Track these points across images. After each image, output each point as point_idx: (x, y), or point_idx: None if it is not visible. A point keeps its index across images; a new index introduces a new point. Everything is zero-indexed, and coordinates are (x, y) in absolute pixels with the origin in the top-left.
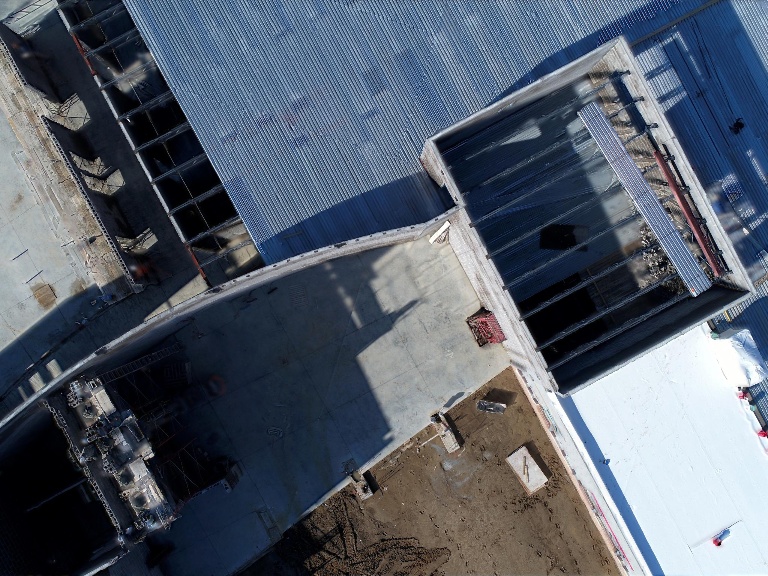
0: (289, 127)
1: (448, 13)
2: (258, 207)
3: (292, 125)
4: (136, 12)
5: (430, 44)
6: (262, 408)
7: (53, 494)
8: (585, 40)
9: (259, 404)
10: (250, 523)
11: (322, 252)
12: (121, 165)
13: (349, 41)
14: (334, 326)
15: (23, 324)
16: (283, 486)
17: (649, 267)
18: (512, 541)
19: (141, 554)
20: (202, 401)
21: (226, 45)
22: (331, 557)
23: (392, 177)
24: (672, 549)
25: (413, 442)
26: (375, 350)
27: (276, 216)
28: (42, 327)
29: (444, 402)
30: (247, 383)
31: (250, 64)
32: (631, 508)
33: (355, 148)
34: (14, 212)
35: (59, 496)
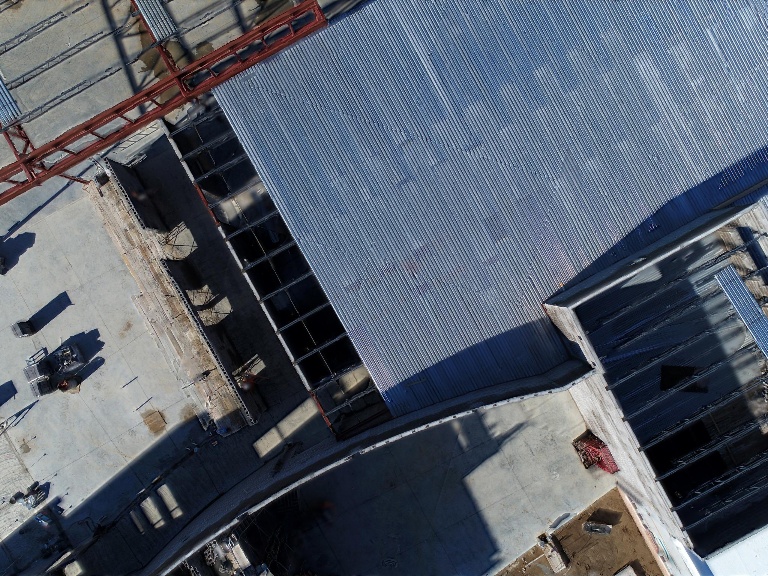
0: (412, 275)
1: (570, 158)
2: (382, 355)
3: (415, 273)
4: (260, 163)
5: (552, 190)
6: (370, 530)
7: None
8: (707, 182)
9: (367, 526)
10: None
11: None
12: (228, 292)
13: (471, 188)
14: (441, 449)
15: (134, 450)
16: None
17: None
18: None
19: None
20: (311, 524)
21: (349, 195)
22: None
23: (515, 323)
24: None
25: (519, 562)
26: (481, 472)
27: (400, 364)
28: (152, 453)
29: (550, 523)
30: (355, 506)
31: (373, 213)
32: None
33: (478, 295)
34: (123, 340)
35: None
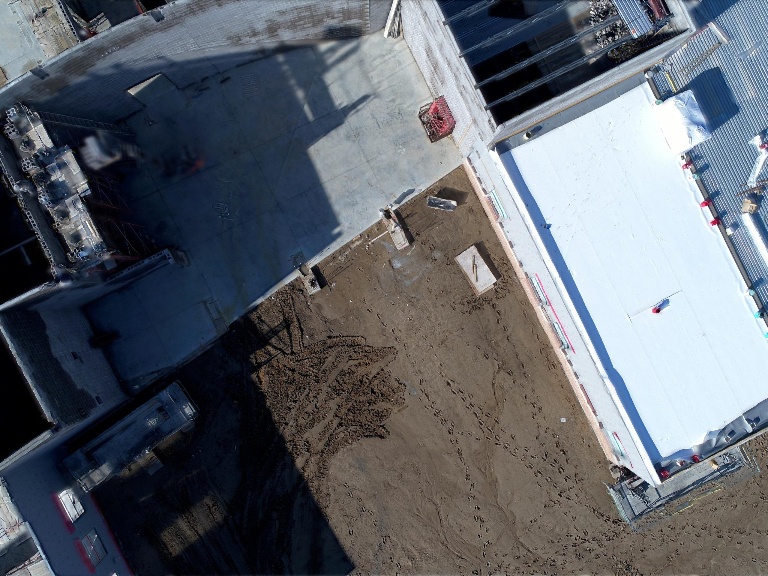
0: None
1: None
2: None
3: None
4: None
5: None
6: (211, 198)
7: None
8: None
9: (208, 194)
10: (196, 314)
11: None
12: None
13: None
14: (286, 118)
15: None
16: (230, 277)
17: (596, 36)
18: (459, 342)
19: (83, 332)
20: (151, 189)
21: None
22: (277, 352)
23: None
24: (611, 316)
25: (362, 239)
26: (327, 143)
27: None
28: None
29: (394, 198)
30: (197, 172)
31: None
32: (571, 274)
33: None
34: None
35: None
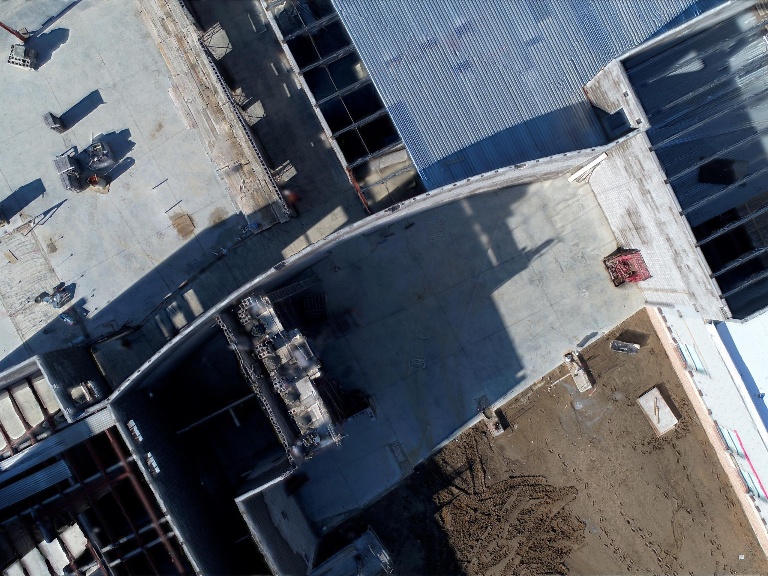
0: (454, 53)
1: None
2: (421, 132)
3: (457, 51)
4: None
5: None
6: (396, 343)
7: (203, 417)
8: None
9: (393, 339)
10: (381, 456)
11: (502, 172)
12: (262, 96)
13: None
14: (470, 263)
15: (161, 253)
16: (415, 421)
17: None
18: (639, 481)
19: (279, 482)
20: (337, 334)
21: None
22: (460, 492)
23: (555, 106)
24: None
25: (545, 381)
26: (510, 288)
27: (439, 142)
28: (180, 257)
29: (577, 341)
30: (382, 318)
31: None
32: None
33: (519, 75)
34: (154, 141)
35: (208, 419)
